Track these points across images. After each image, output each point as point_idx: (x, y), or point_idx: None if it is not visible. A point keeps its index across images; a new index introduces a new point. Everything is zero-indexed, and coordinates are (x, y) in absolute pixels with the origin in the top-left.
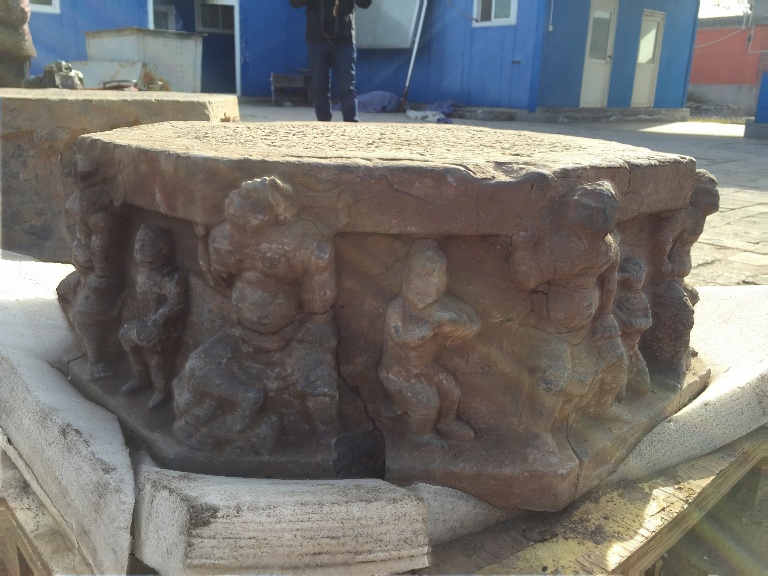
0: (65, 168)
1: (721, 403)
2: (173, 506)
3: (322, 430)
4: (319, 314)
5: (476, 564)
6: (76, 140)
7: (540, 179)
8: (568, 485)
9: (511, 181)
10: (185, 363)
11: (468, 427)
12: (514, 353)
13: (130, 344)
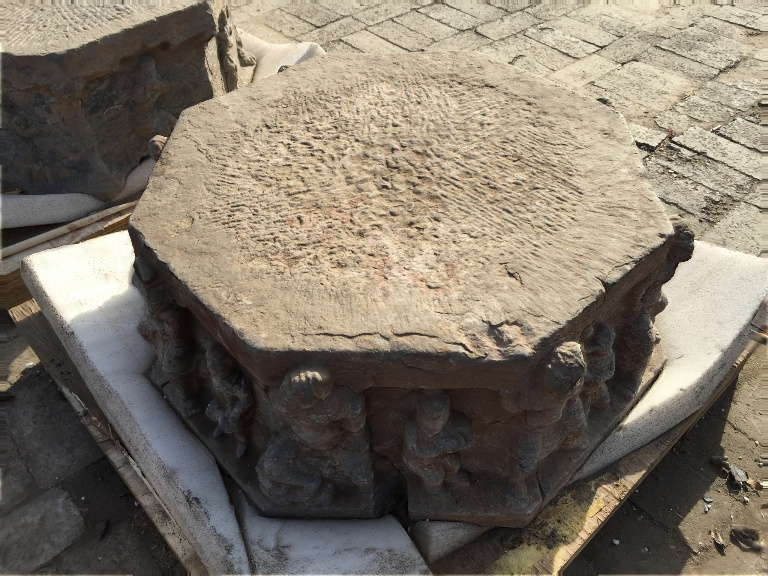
0: (87, 107)
1: (664, 407)
2: None
3: (363, 491)
4: (356, 433)
5: (468, 573)
6: (90, 78)
7: (522, 360)
8: (533, 514)
9: (500, 361)
10: (258, 431)
11: (465, 479)
12: (500, 437)
13: None
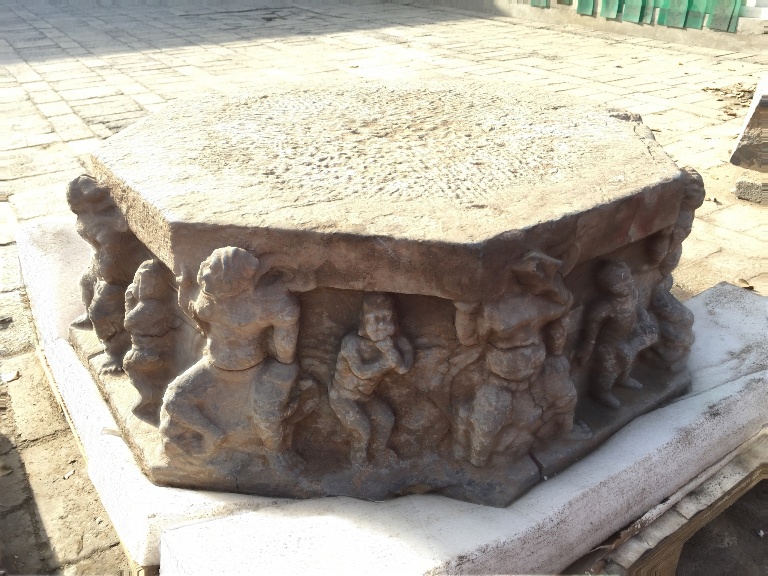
0: None
1: None
2: None
3: None
4: None
5: None
6: None
7: None
8: None
9: None
10: None
11: None
12: None
13: None
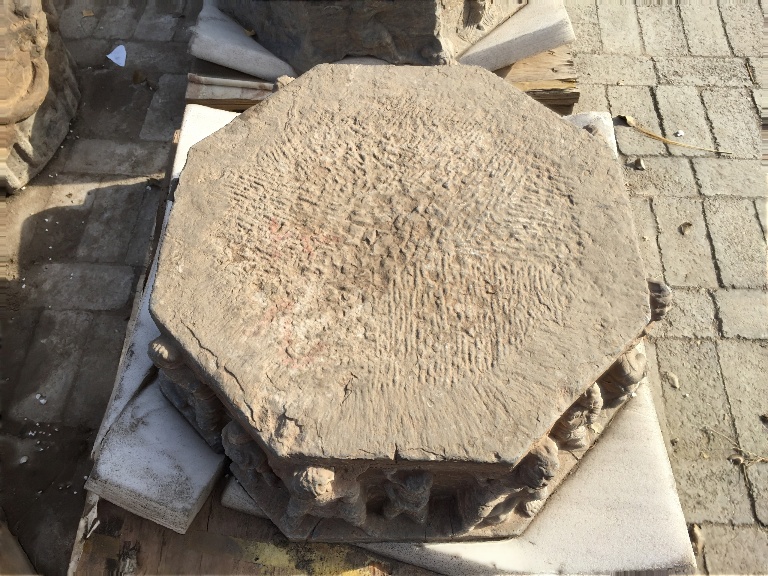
0: None
1: (468, 564)
2: None
3: None
4: None
5: (237, 532)
6: None
7: (275, 455)
8: (297, 540)
9: (264, 442)
10: None
11: (271, 481)
12: None
13: None
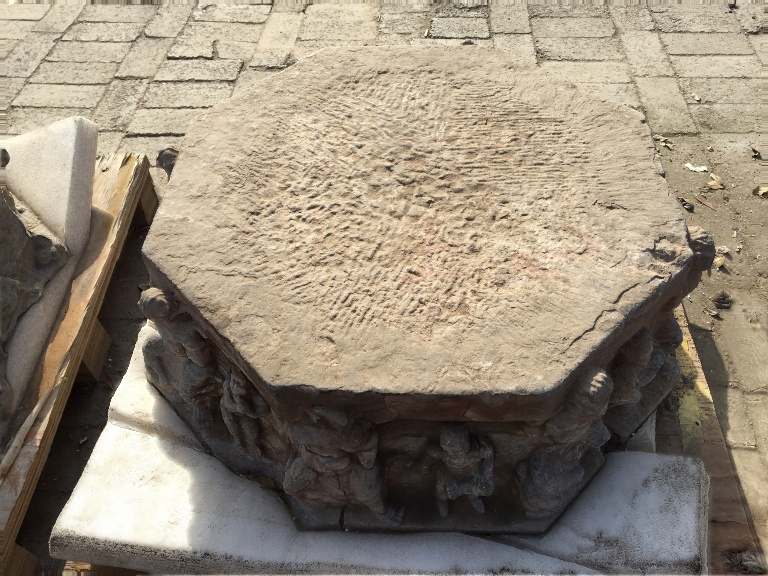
0: None
1: None
2: (670, 571)
3: None
4: None
5: (676, 446)
6: None
7: (692, 259)
8: None
9: (681, 270)
10: None
11: None
12: None
13: (458, 496)
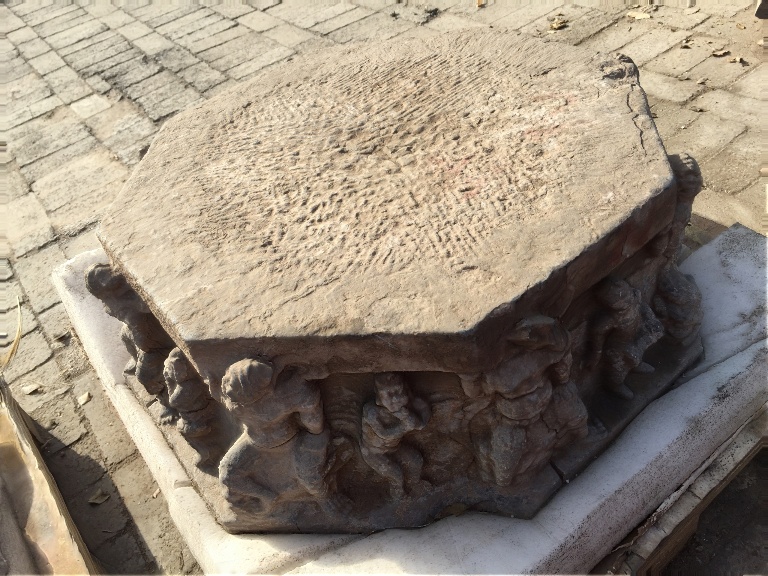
0: None
1: None
2: None
3: None
4: None
5: (695, 247)
6: None
7: None
8: None
9: None
10: None
11: None
12: None
13: None
